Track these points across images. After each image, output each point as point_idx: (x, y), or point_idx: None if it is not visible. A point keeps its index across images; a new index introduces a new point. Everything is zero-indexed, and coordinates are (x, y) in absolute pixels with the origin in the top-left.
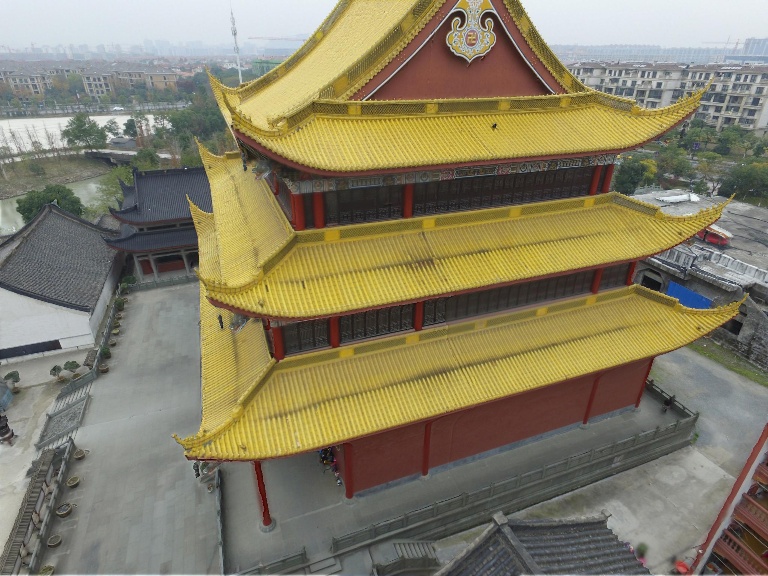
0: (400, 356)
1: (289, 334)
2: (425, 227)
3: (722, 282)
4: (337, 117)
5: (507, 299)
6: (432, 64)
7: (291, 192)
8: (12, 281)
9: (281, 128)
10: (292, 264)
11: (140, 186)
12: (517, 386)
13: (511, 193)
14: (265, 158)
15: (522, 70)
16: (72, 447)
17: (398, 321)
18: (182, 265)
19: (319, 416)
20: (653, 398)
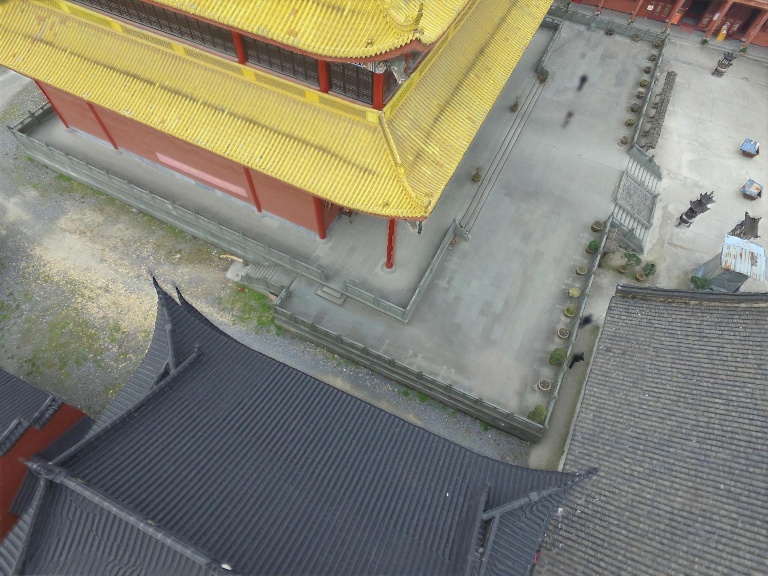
0: None
1: None
2: None
3: None
4: None
5: None
6: None
7: None
8: (765, 339)
9: None
10: None
11: None
12: None
13: None
14: None
15: None
16: None
17: None
18: None
19: None
20: None
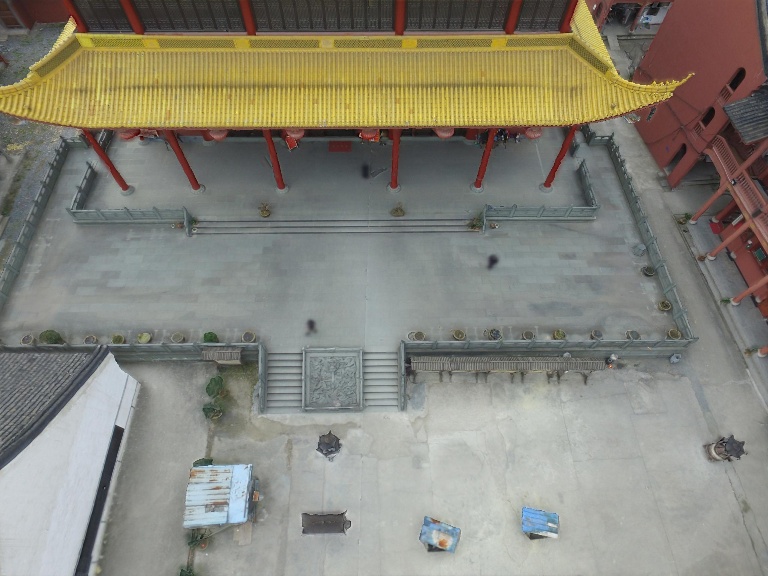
0: None
1: None
2: None
3: None
4: None
5: None
6: None
7: None
8: None
9: None
10: None
11: None
12: None
13: None
14: None
15: None
16: (407, 345)
17: None
18: None
19: None
20: None
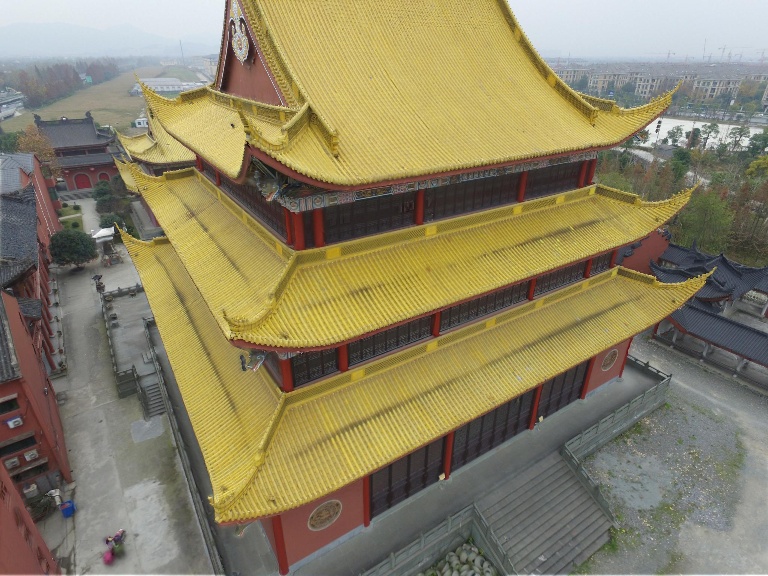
0: None
1: None
2: None
3: None
4: None
5: None
6: (239, 66)
7: None
8: None
9: (175, 100)
10: None
11: None
12: None
13: None
14: None
15: None
16: None
17: None
18: None
19: (157, 270)
20: None
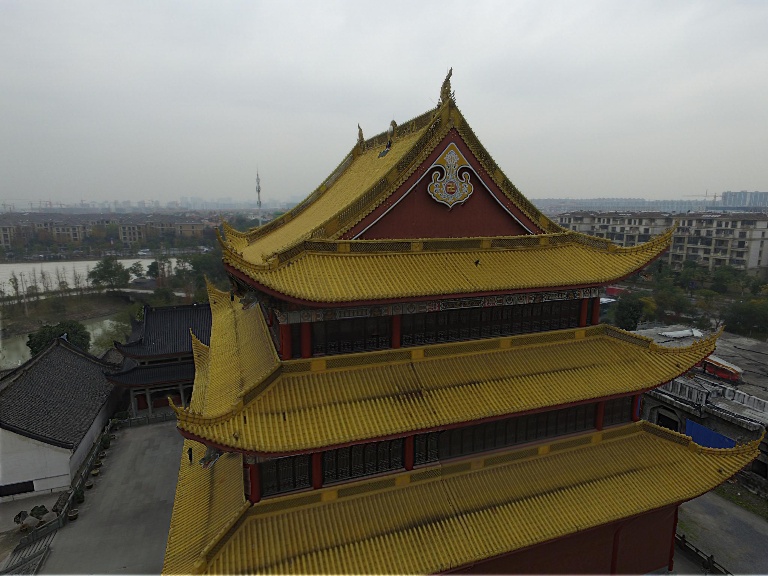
0: (389, 500)
1: (267, 472)
2: (414, 358)
3: (741, 420)
4: (327, 254)
5: (504, 435)
6: (416, 209)
7: (279, 322)
8: (0, 415)
9: (272, 263)
10: (275, 395)
11: (149, 321)
12: (521, 539)
13: (500, 325)
14: (253, 289)
15: (500, 214)
16: None
17: (387, 459)
18: (179, 400)
19: (293, 574)
20: (688, 559)
